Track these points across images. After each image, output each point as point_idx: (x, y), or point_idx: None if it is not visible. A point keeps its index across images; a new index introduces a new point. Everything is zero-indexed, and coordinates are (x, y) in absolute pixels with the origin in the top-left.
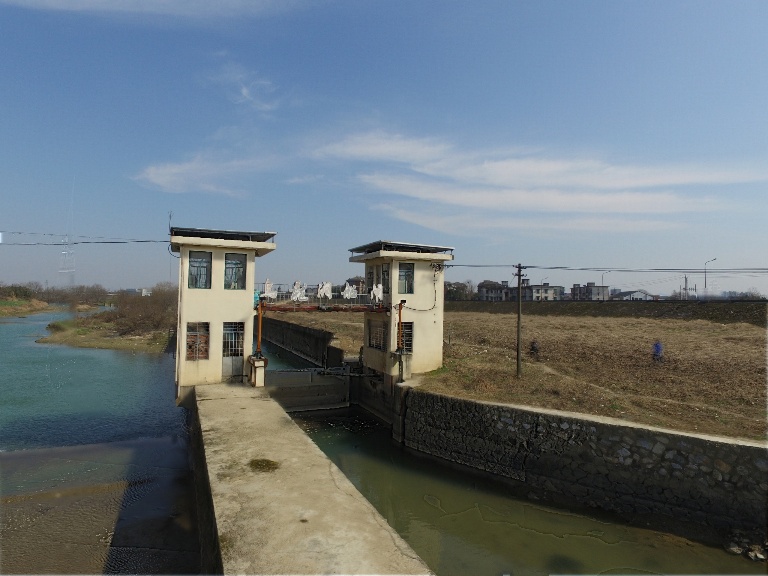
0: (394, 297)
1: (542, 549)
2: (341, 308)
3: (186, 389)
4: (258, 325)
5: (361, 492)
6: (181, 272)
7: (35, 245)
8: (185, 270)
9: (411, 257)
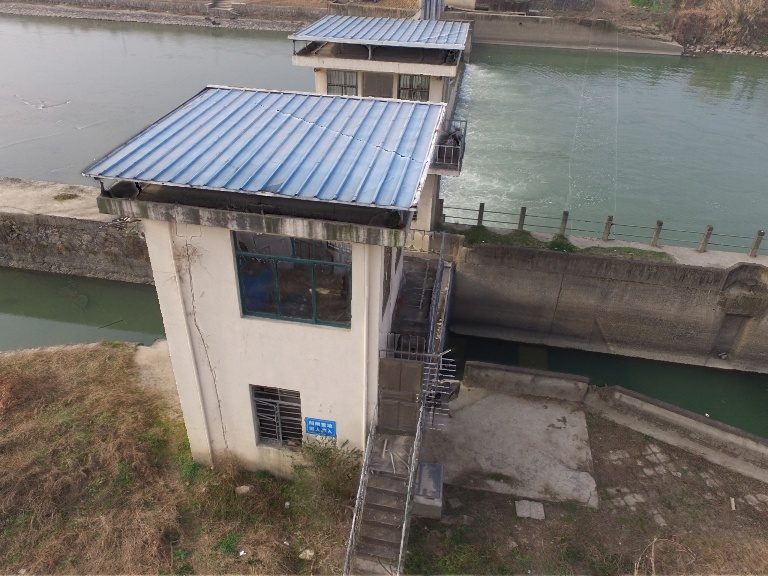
0: None
1: None
2: None
3: None
4: None
5: None
6: None
7: None
8: None
9: None
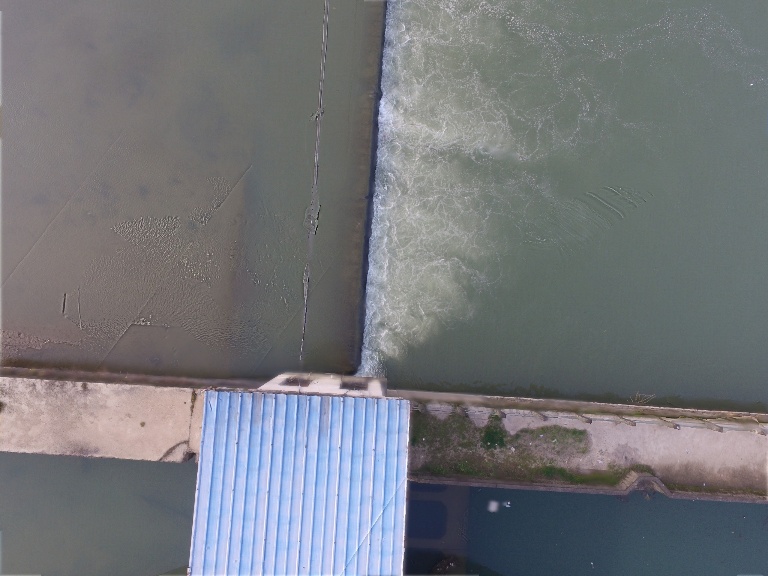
0: None
1: (5, 572)
2: None
3: None
4: None
5: (139, 500)
6: None
7: None
8: None
9: None
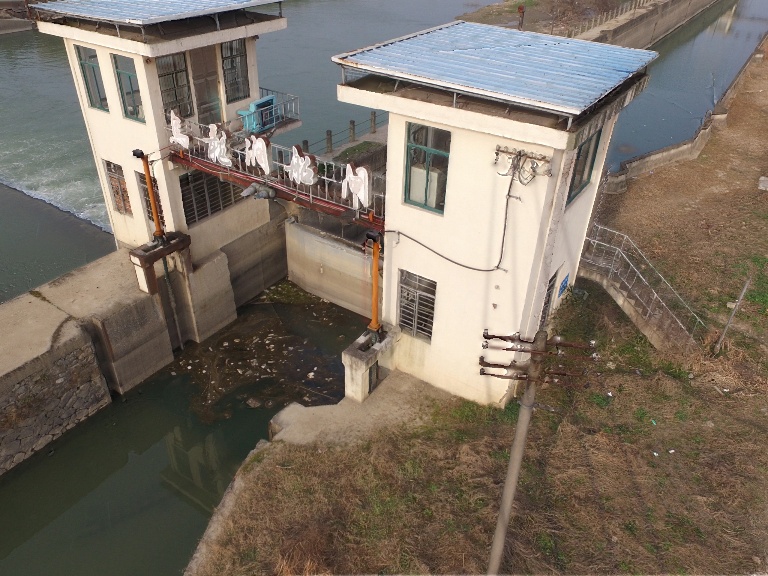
0: (391, 209)
1: None
2: (293, 197)
3: (125, 245)
4: (149, 195)
5: (75, 539)
6: (76, 80)
7: (6, 12)
8: (79, 77)
9: (423, 116)
